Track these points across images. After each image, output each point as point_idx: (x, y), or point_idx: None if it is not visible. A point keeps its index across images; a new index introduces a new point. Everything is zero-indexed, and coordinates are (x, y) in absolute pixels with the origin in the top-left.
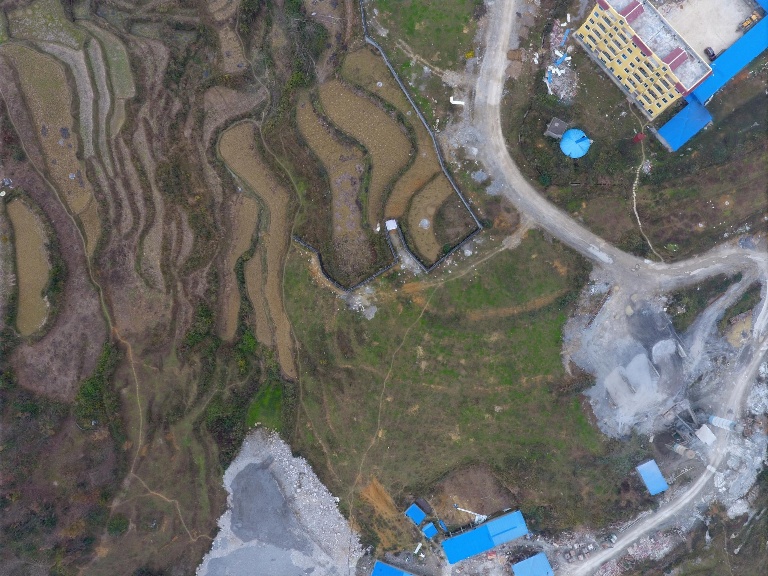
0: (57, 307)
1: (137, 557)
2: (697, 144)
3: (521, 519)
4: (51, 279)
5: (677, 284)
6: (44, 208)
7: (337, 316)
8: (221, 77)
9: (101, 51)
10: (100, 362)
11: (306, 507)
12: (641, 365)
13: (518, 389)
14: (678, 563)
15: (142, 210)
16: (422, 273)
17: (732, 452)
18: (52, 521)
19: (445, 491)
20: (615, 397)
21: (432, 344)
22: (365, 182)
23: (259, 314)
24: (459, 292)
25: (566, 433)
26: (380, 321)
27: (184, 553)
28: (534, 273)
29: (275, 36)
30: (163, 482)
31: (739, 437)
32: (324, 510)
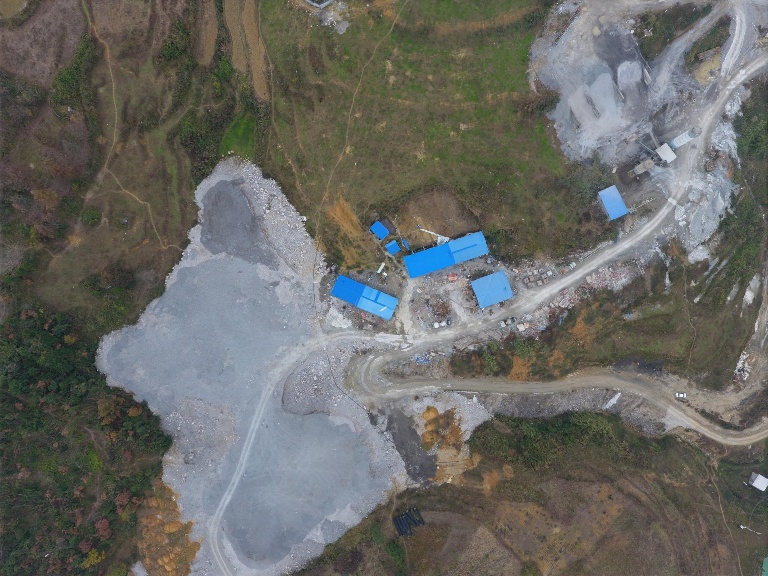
0: None
1: (109, 253)
2: None
3: (482, 238)
4: None
5: (645, 9)
6: None
7: (310, 33)
8: None
9: None
10: (78, 53)
11: (274, 227)
12: (606, 90)
13: (484, 106)
14: (637, 304)
15: None
16: None
17: (694, 186)
18: (27, 200)
19: (409, 212)
20: None
21: (401, 59)
22: None
23: (236, 42)
24: (429, 4)
25: (529, 155)
26: (351, 36)
27: (154, 259)
28: None
29: None
30: (136, 183)
31: (701, 171)
32: (291, 229)
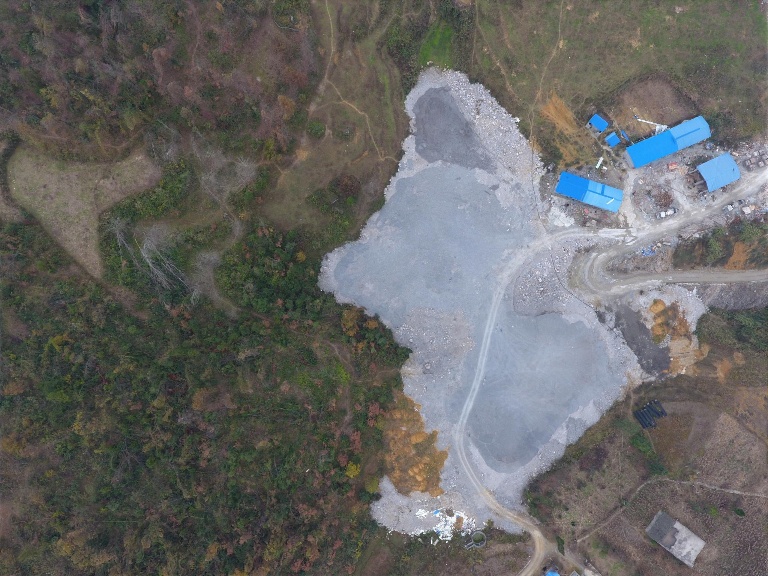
0: None
1: (333, 166)
2: None
3: (704, 122)
4: None
5: None
6: None
7: None
8: None
9: None
10: None
11: (485, 132)
12: None
13: None
14: None
15: None
16: None
17: None
18: (258, 114)
19: (625, 103)
20: None
21: None
22: None
23: None
24: None
25: (746, 33)
26: None
27: (373, 171)
28: None
29: None
30: (354, 93)
31: None
32: (504, 131)
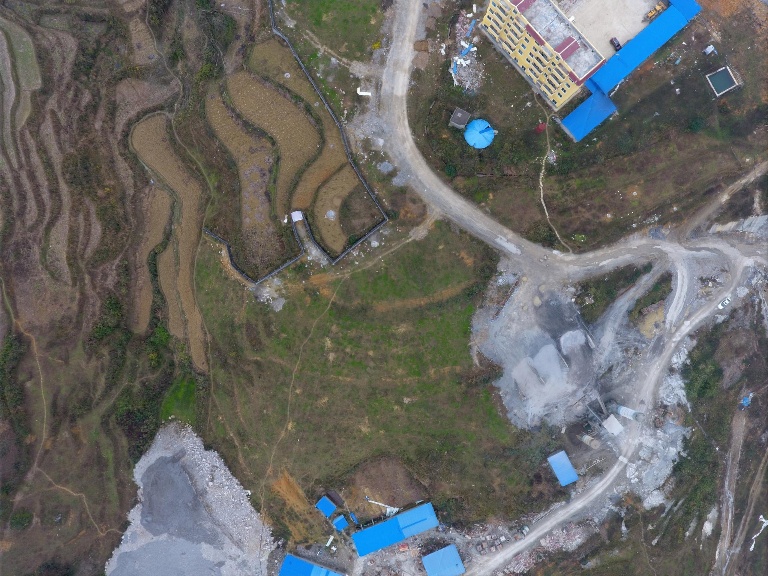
0: None
1: (42, 551)
2: (602, 134)
3: (431, 511)
4: None
5: (586, 275)
6: None
7: (246, 308)
8: (132, 69)
9: (6, 42)
10: (1, 355)
11: (218, 500)
12: (550, 356)
13: (427, 380)
14: (594, 554)
15: (47, 202)
16: (329, 264)
17: (644, 443)
18: None
19: (356, 483)
20: (525, 388)
21: (340, 336)
22: (274, 174)
23: (172, 307)
24: (365, 283)
25: (476, 424)
26: (288, 313)
27: (92, 547)
28: (441, 264)
29: (187, 28)
30: (69, 476)
31: (651, 428)
32: (236, 503)
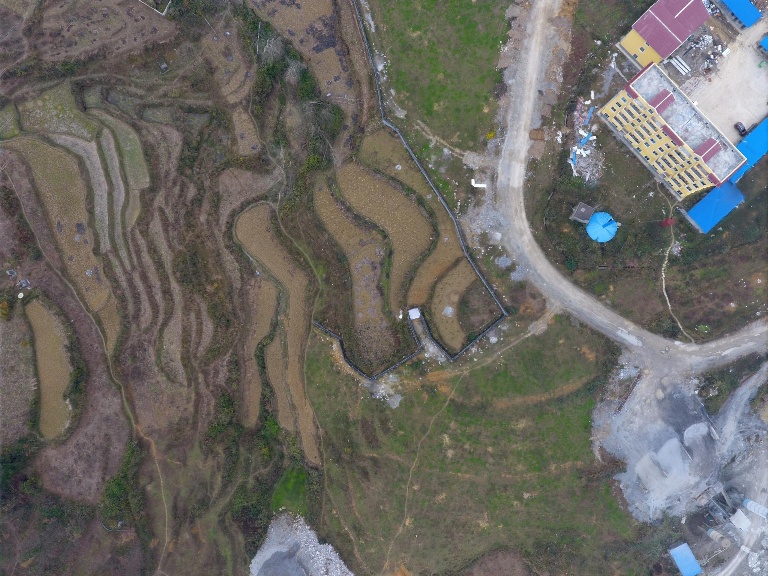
0: (79, 409)
1: None
2: (728, 224)
3: None
4: (72, 382)
5: (708, 365)
6: (62, 308)
7: (361, 404)
8: (236, 160)
9: (114, 141)
10: (124, 462)
11: None
12: (672, 448)
13: (547, 476)
14: None
15: (161, 303)
16: (447, 361)
17: (766, 532)
18: None
19: None
20: (646, 481)
21: (458, 432)
22: (386, 267)
23: (281, 399)
24: (485, 380)
25: (596, 518)
26: (405, 410)
27: None
28: (561, 359)
29: (289, 116)
30: None
31: None
32: None
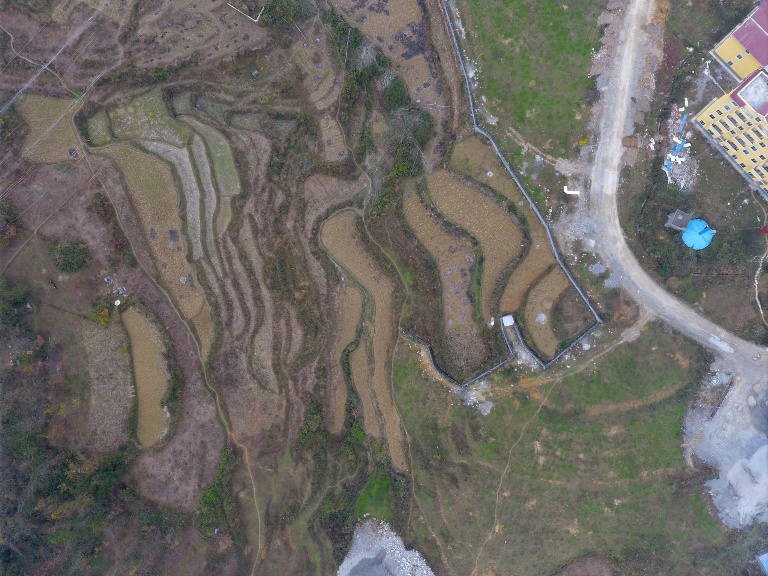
0: (176, 417)
1: None
2: None
3: None
4: (170, 389)
5: None
6: (158, 315)
7: (451, 411)
8: (322, 166)
9: (205, 148)
10: (219, 469)
11: None
12: (763, 454)
13: (638, 482)
14: None
15: (252, 310)
16: (539, 368)
17: None
18: None
19: None
20: (736, 487)
21: (550, 439)
22: (476, 274)
23: (366, 406)
24: (578, 387)
25: (686, 524)
26: (496, 416)
27: None
28: (654, 366)
29: (376, 122)
30: None
31: None
32: None
